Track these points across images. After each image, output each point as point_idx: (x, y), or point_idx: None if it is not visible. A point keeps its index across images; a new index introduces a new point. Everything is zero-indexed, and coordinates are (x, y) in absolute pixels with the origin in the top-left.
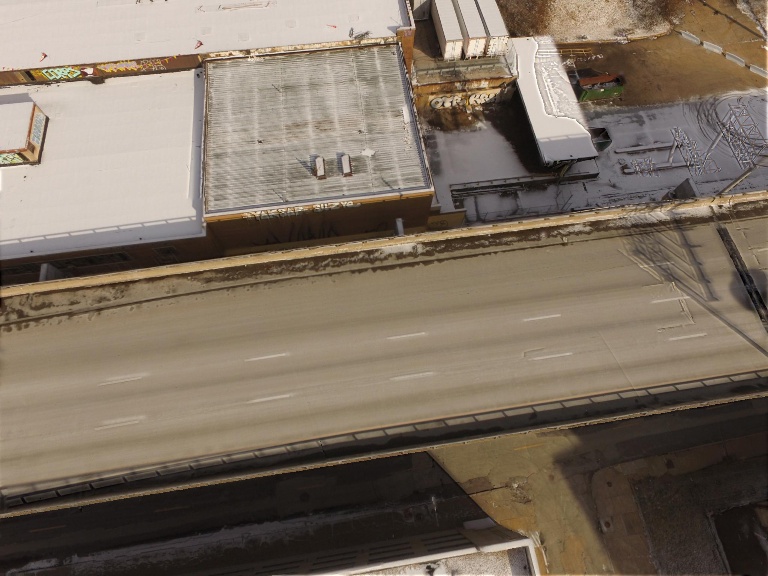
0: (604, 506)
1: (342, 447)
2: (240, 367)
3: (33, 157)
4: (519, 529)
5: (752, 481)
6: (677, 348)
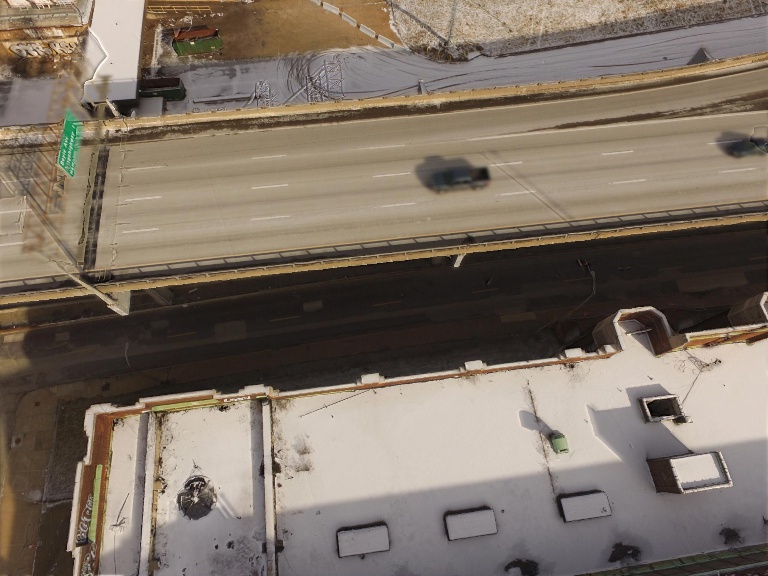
0: (22, 424)
1: None
2: None
3: None
4: None
5: None
6: None
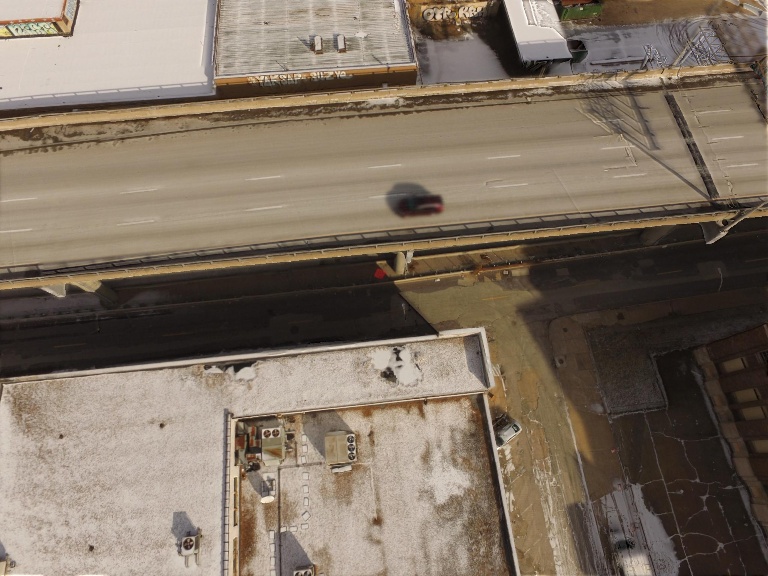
0: (559, 347)
1: (325, 245)
2: (241, 184)
3: (67, 29)
4: None
5: (693, 331)
6: (620, 183)
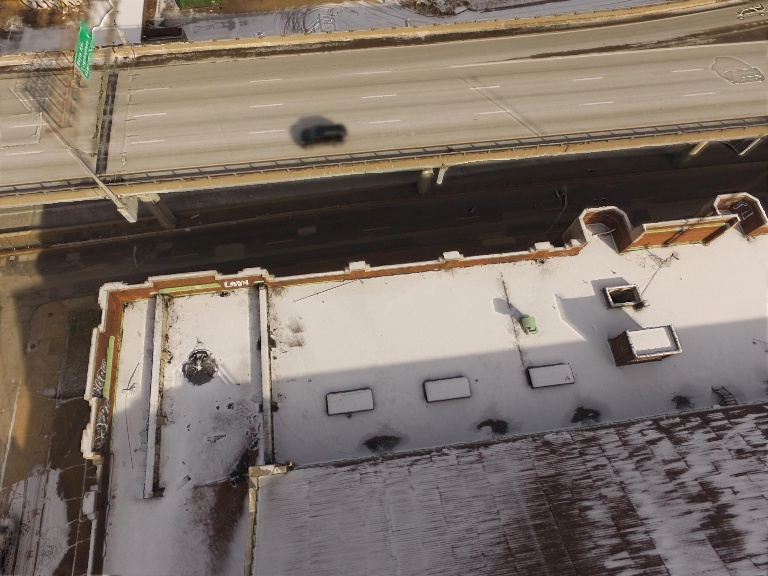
0: (37, 332)
1: None
2: None
3: None
4: None
5: None
6: (9, 161)
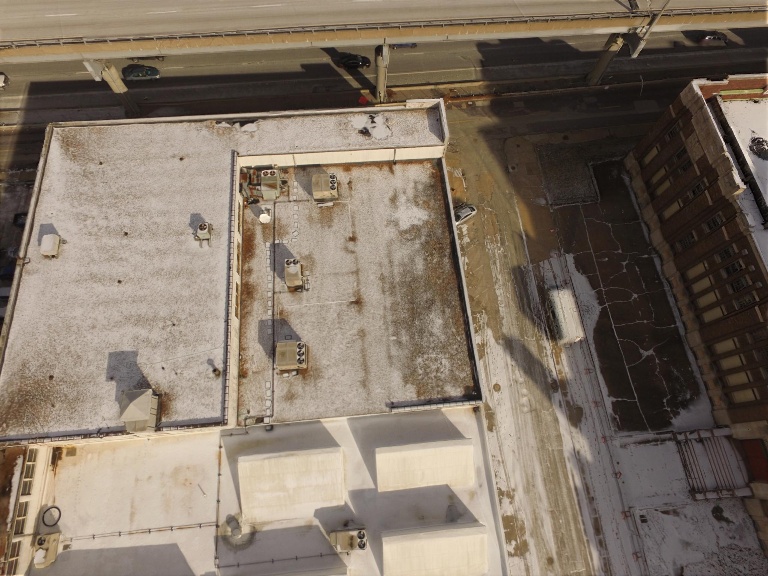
0: (512, 157)
1: None
2: None
3: None
4: (447, 166)
5: (625, 147)
6: None
